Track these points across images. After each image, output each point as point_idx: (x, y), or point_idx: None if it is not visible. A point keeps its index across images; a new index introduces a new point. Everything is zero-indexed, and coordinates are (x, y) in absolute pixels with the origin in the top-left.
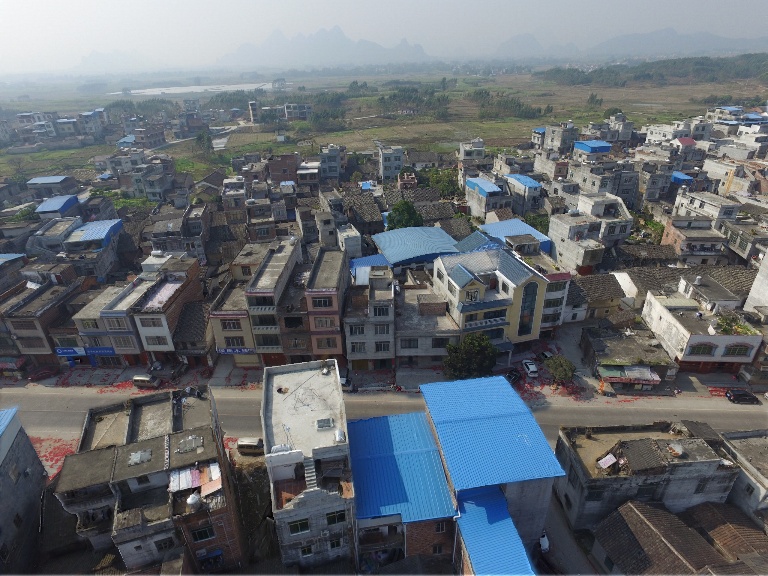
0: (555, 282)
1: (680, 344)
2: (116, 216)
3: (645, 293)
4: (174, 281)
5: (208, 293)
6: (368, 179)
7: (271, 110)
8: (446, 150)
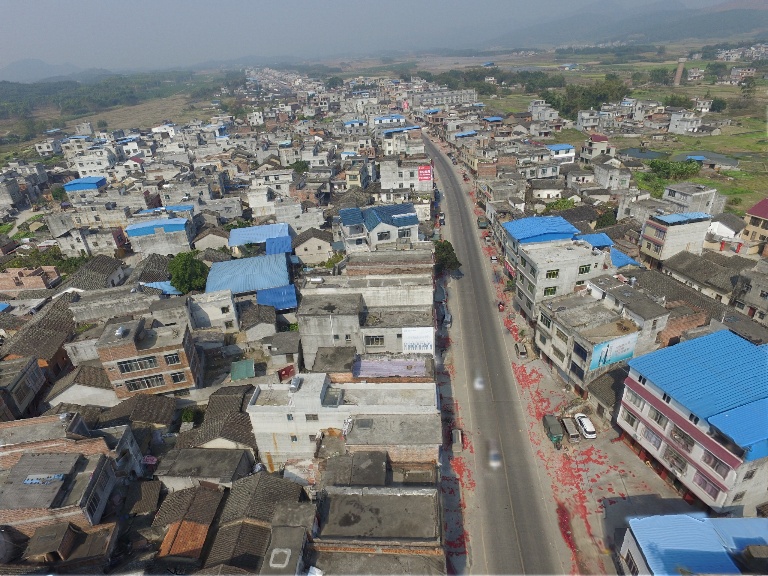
0: None
1: (426, 213)
2: None
3: None
4: (353, 373)
5: None
6: None
7: None
8: None
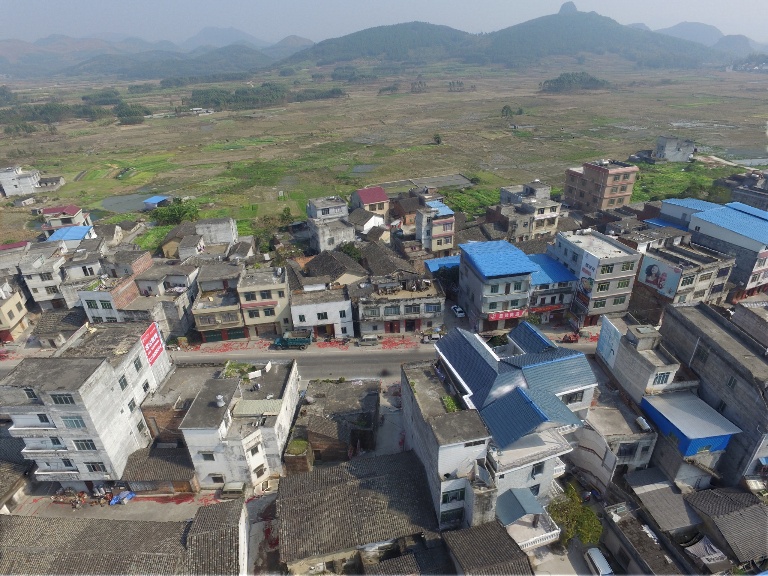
0: None
1: None
2: None
3: (236, 500)
4: None
5: None
6: None
7: None
8: None
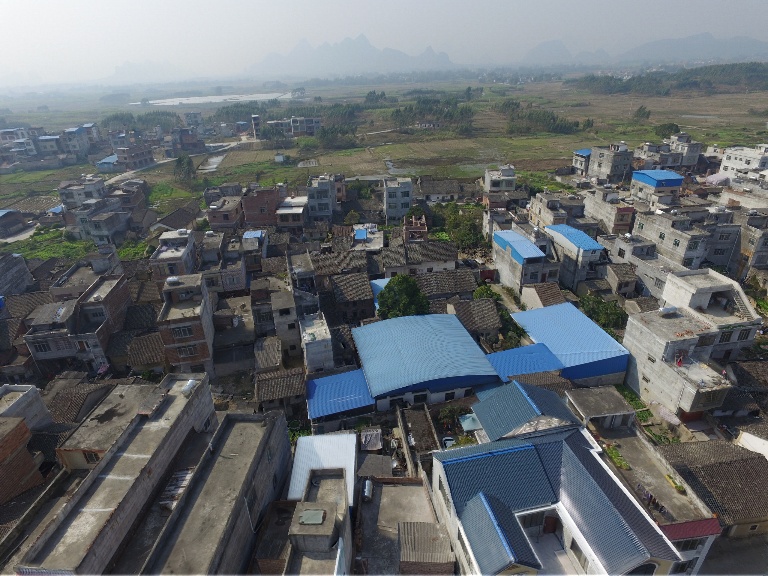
0: (685, 537)
1: None
2: (28, 277)
3: None
4: None
5: (57, 463)
6: (368, 219)
7: (277, 124)
8: (469, 175)
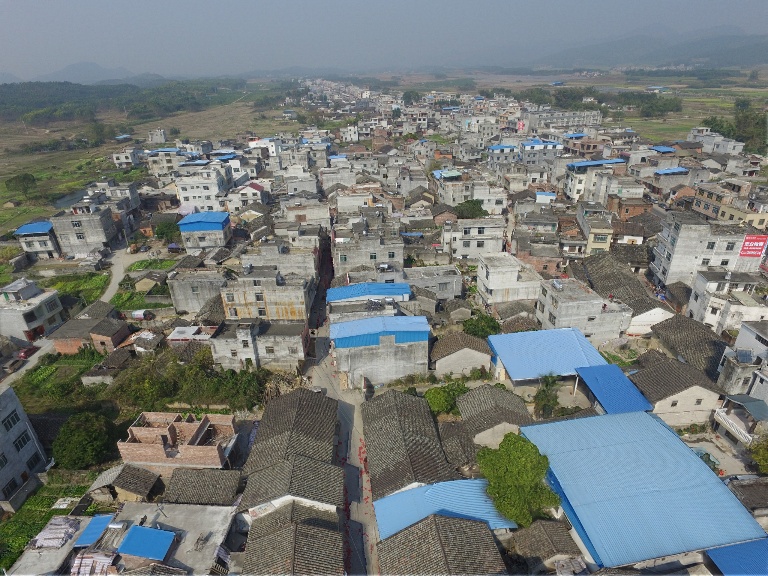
0: None
1: None
2: None
3: None
4: None
5: None
6: None
7: None
8: None
